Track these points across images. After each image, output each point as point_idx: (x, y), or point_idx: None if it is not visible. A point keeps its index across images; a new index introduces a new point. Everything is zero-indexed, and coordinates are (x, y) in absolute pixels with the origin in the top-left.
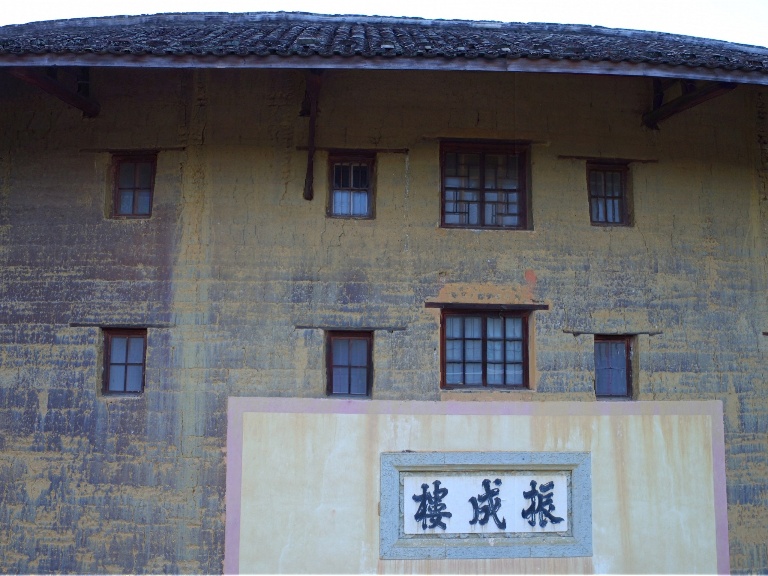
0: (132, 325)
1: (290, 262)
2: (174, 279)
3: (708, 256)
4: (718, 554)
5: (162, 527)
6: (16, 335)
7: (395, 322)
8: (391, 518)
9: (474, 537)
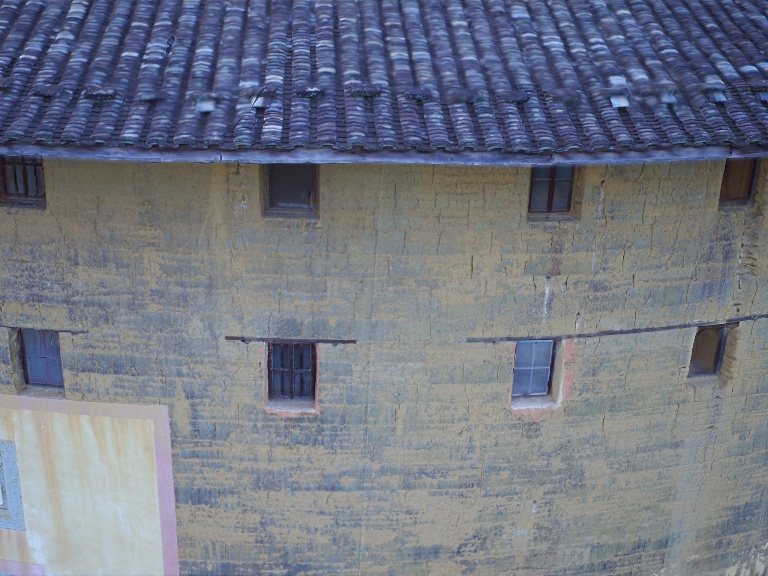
0: None
1: None
2: None
3: (148, 247)
4: (164, 545)
5: None
6: None
7: None
8: None
9: None
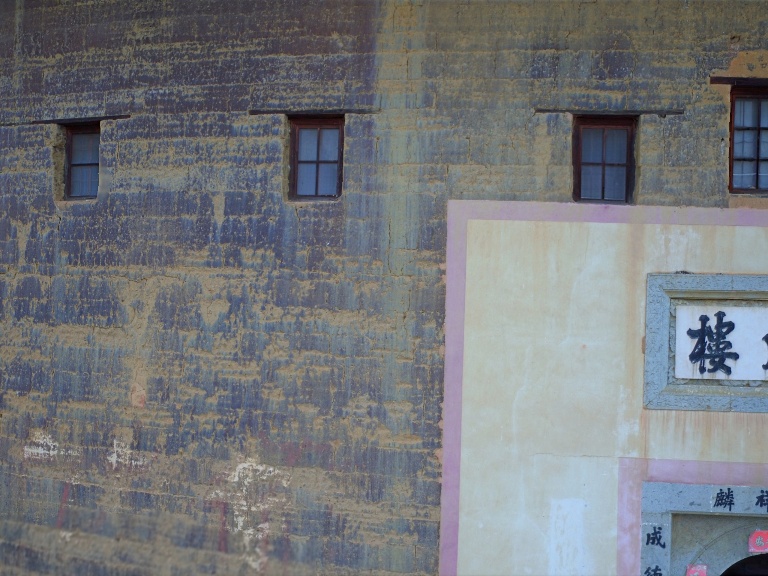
0: (326, 111)
1: (529, 25)
2: (378, 51)
3: None
4: None
5: (365, 360)
6: (184, 127)
7: (669, 103)
8: (659, 357)
9: (767, 386)
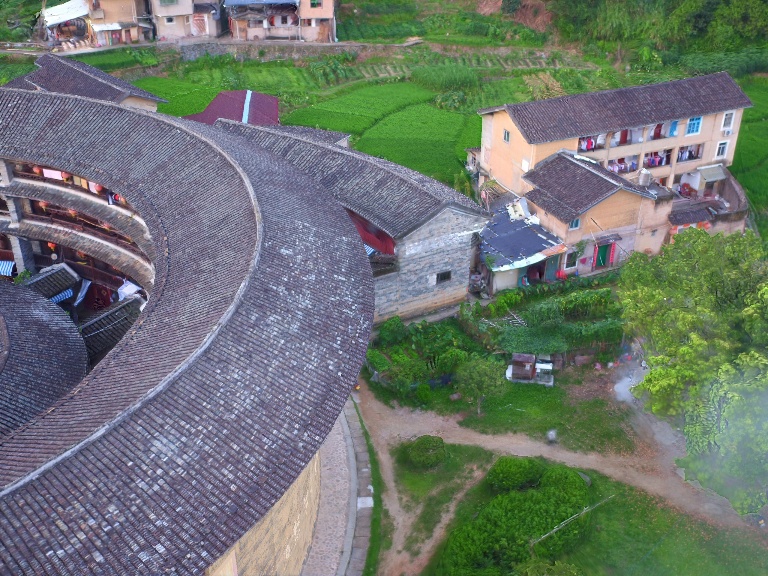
0: None
1: None
2: None
3: None
4: None
5: None
6: None
7: None
8: None
9: None
